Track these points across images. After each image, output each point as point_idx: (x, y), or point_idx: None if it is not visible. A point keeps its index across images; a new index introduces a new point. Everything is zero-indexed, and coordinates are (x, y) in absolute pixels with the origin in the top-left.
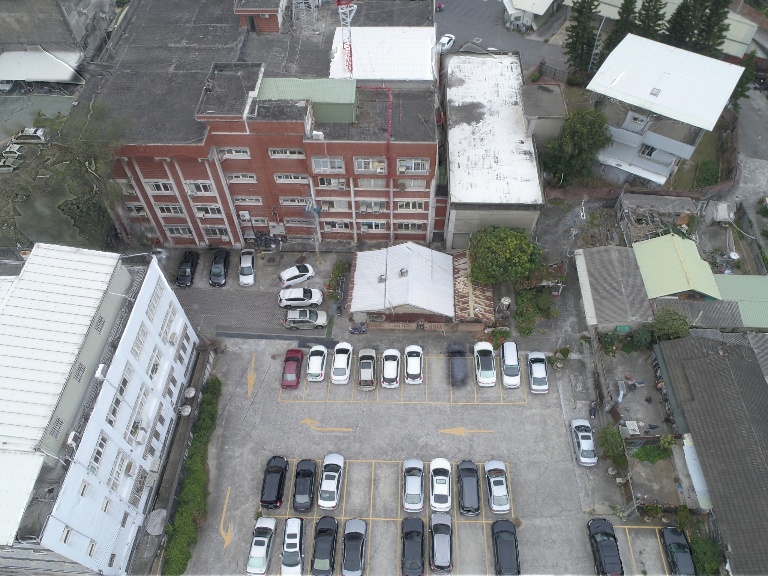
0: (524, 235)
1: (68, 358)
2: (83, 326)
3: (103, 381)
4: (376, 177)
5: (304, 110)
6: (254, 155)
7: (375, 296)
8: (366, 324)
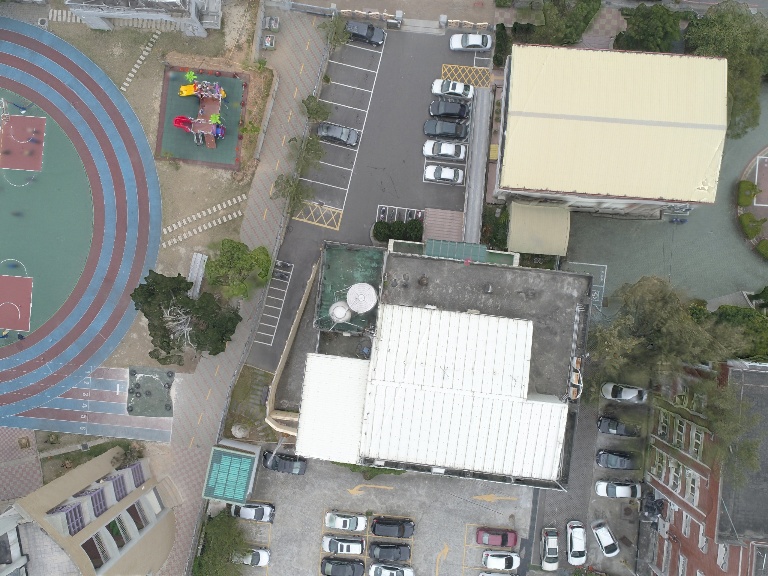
0: None
1: (440, 461)
2: (473, 465)
3: (431, 472)
4: None
5: None
6: (721, 571)
7: None
8: None
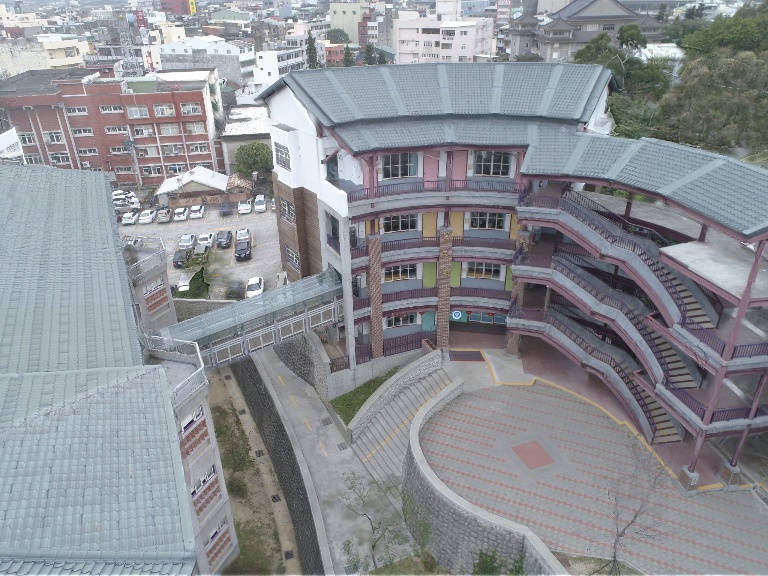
0: (265, 144)
1: None
2: None
3: None
4: (170, 121)
5: (121, 81)
6: (90, 112)
7: (173, 187)
8: (168, 206)
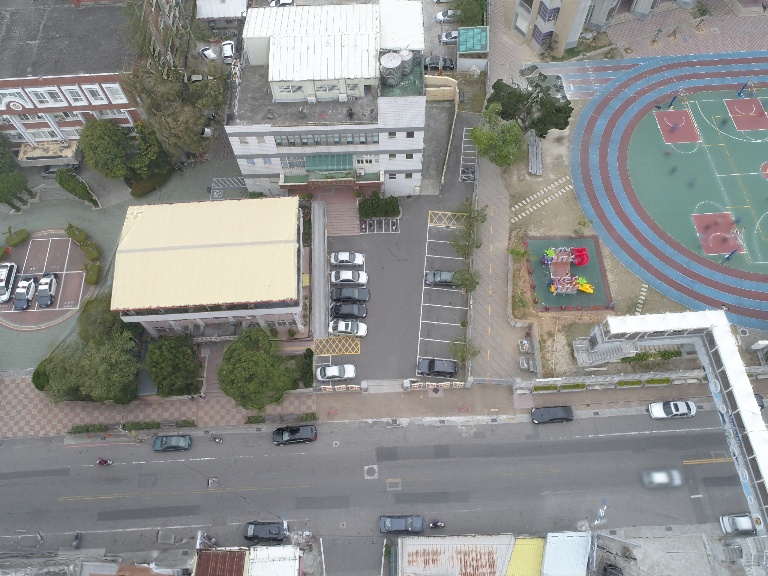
0: None
1: (325, 7)
2: (303, 8)
3: None
4: None
5: None
6: None
7: (236, 4)
8: None
